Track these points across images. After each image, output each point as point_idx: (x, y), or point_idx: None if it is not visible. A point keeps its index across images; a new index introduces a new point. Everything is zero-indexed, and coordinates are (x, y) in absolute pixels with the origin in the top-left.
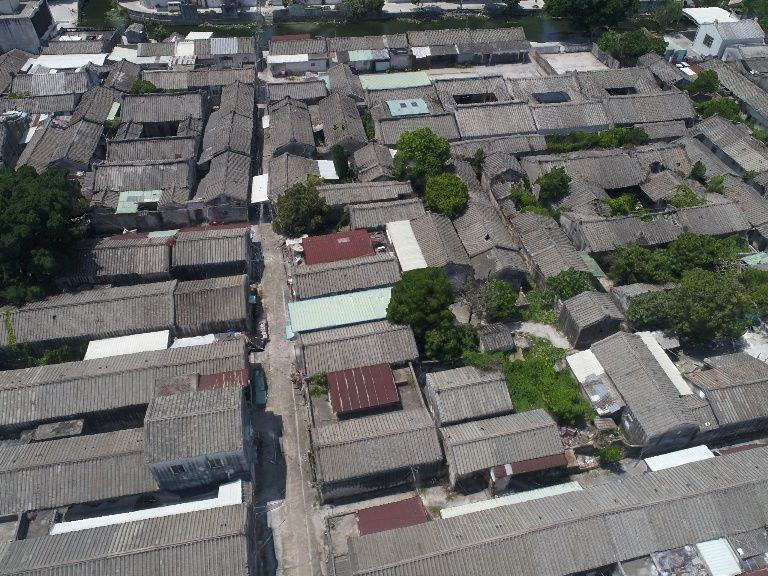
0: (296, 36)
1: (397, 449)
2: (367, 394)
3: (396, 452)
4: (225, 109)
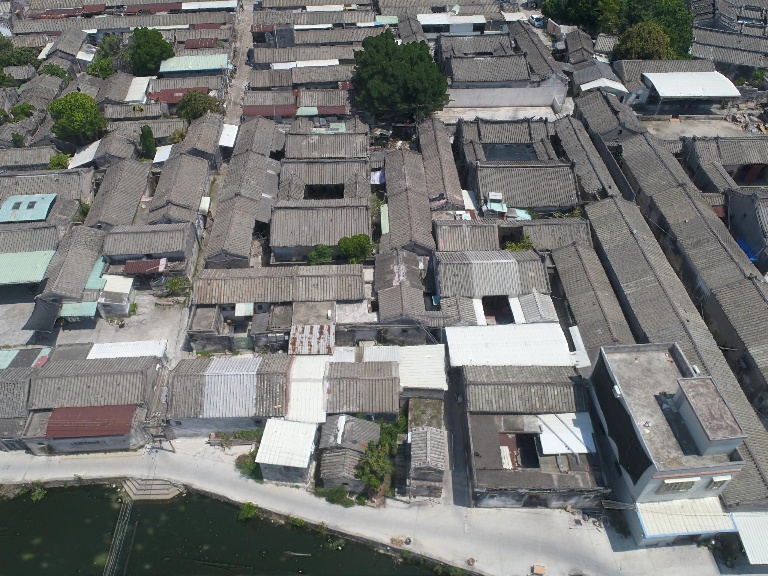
0: (80, 416)
1: None
2: None
3: None
4: (248, 211)
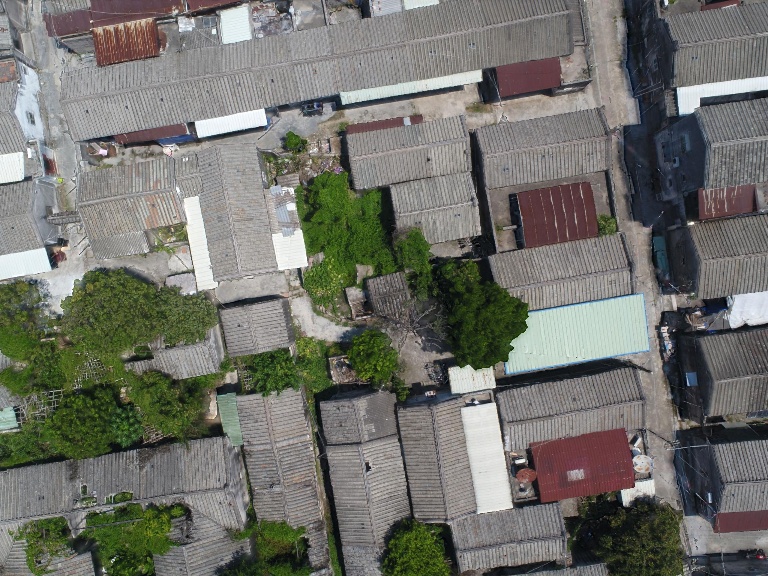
0: None
1: (523, 135)
2: (553, 203)
3: (524, 133)
4: None
